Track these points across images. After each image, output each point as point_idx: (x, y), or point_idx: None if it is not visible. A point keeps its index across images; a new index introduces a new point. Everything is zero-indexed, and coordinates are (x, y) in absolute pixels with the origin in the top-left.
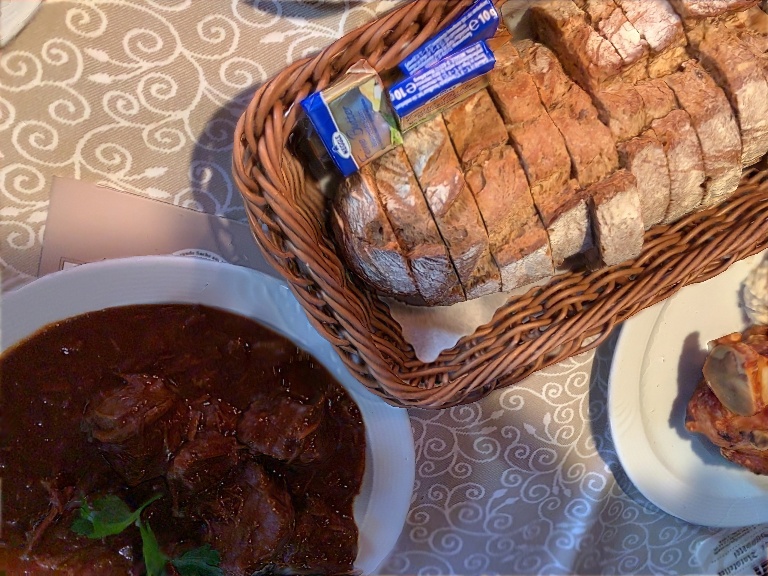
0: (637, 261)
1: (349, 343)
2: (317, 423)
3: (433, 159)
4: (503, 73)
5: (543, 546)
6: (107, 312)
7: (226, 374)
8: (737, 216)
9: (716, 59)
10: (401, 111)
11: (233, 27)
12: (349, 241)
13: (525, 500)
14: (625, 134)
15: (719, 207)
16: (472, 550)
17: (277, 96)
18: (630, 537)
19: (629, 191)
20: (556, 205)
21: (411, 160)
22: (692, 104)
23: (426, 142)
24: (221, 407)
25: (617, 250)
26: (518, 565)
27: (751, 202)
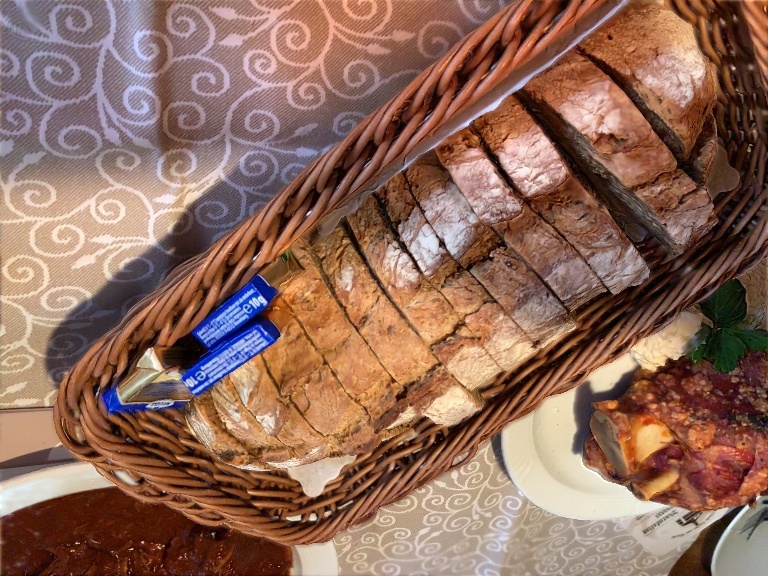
0: (498, 378)
1: (229, 519)
2: (230, 552)
3: (254, 393)
4: (306, 301)
5: (475, 552)
6: (13, 514)
7: (141, 524)
8: (592, 323)
9: (520, 253)
10: (198, 394)
11: (39, 263)
12: (204, 445)
13: (449, 531)
14: (438, 337)
15: (577, 311)
16: (410, 571)
17: (82, 382)
18: (556, 526)
19: (448, 391)
20: (381, 411)
21: (236, 389)
22: (503, 296)
23: (245, 376)
24: (145, 549)
25: (455, 419)
26: (455, 568)
27: (605, 308)
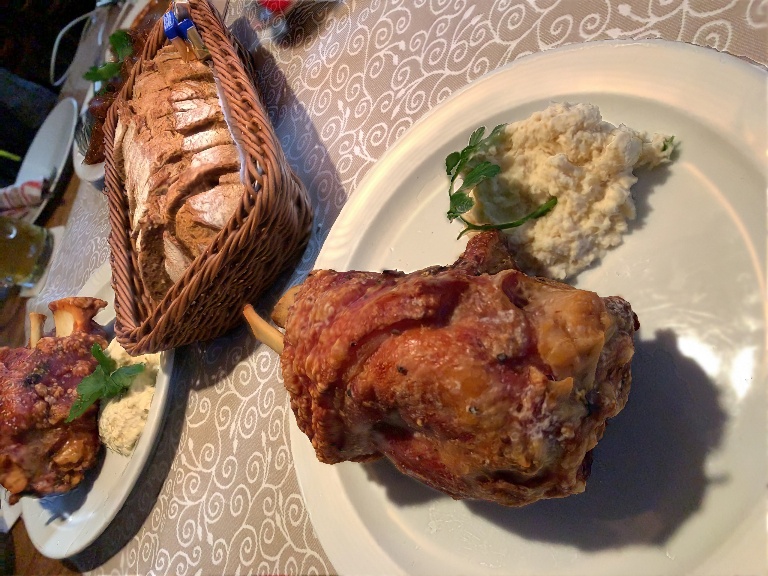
0: None
1: None
2: None
3: None
4: None
5: None
6: None
7: None
8: None
9: None
10: None
11: (266, 0)
12: None
13: None
14: None
15: None
16: None
17: None
18: None
19: None
20: None
21: None
22: None
23: None
24: None
25: None
26: None
27: None
